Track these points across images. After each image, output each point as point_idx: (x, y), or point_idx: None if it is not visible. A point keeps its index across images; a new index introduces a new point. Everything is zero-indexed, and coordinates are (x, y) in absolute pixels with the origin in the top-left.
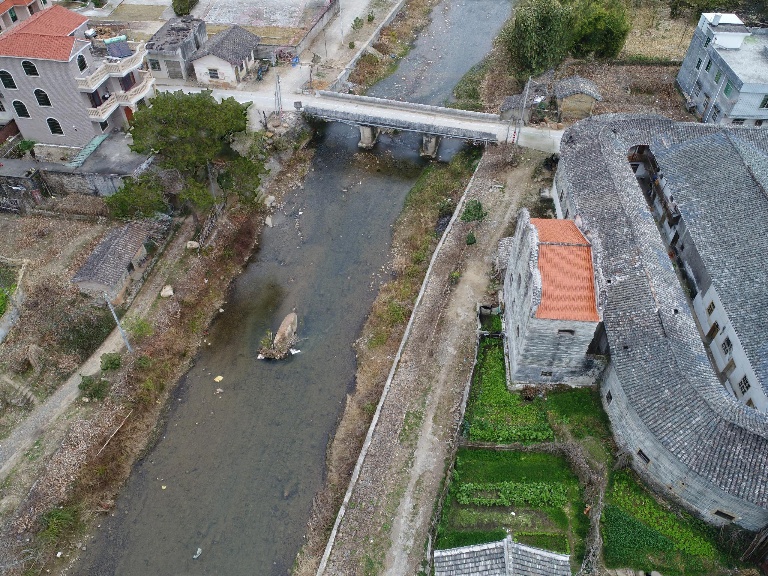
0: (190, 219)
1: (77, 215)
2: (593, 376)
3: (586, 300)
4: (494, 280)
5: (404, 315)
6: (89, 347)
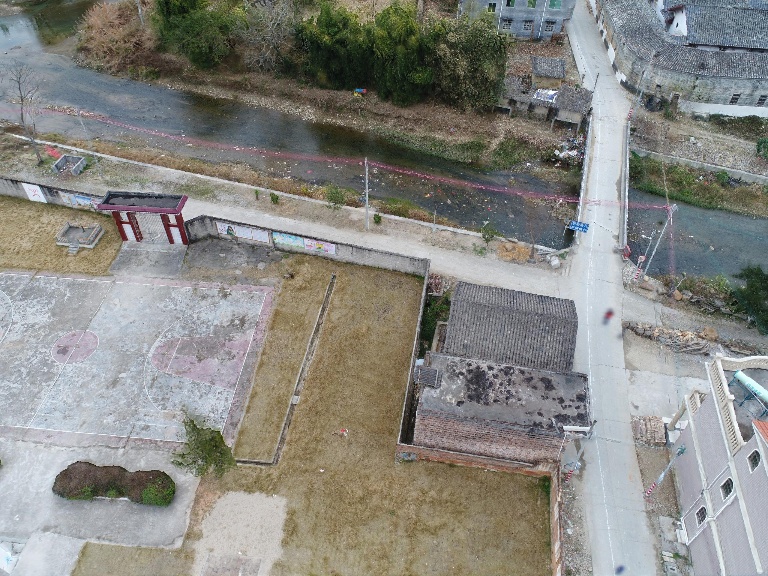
0: None
1: None
2: None
3: None
4: None
5: None
6: None
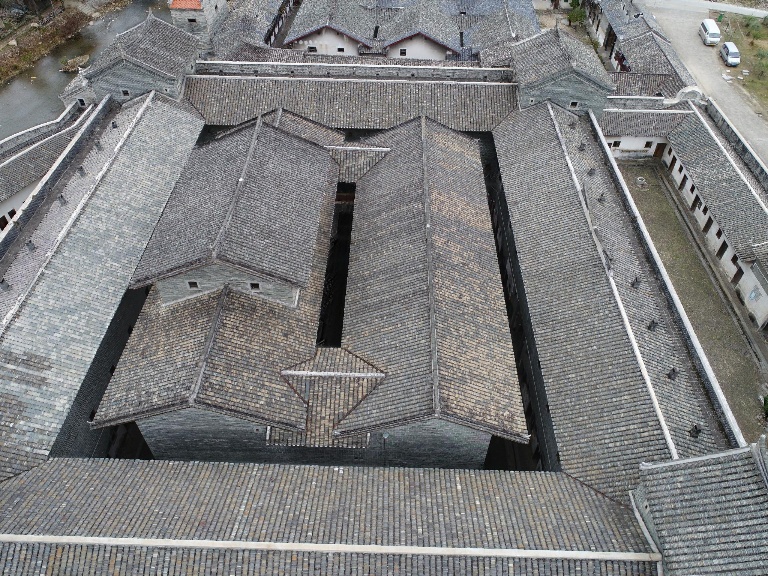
0: None
1: None
2: None
3: (197, 0)
4: None
5: None
6: None
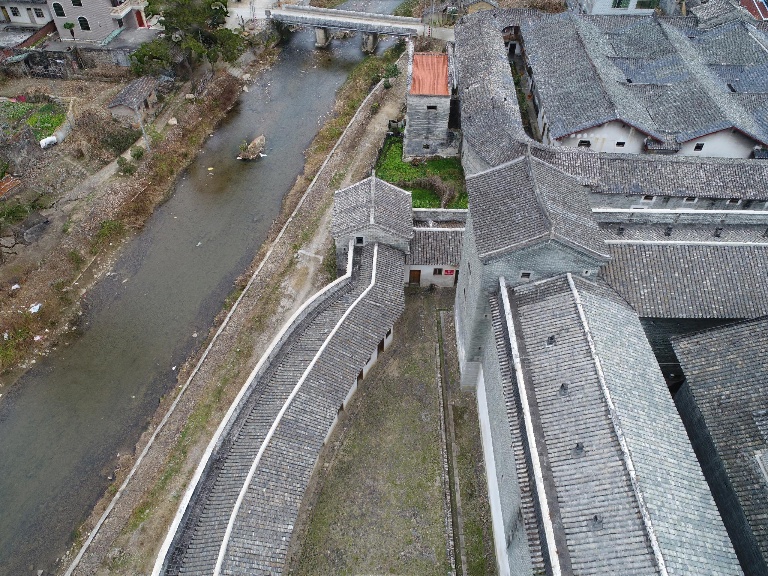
0: (187, 84)
1: (105, 78)
2: (456, 147)
3: (442, 84)
4: (403, 110)
5: (339, 133)
6: (121, 148)
